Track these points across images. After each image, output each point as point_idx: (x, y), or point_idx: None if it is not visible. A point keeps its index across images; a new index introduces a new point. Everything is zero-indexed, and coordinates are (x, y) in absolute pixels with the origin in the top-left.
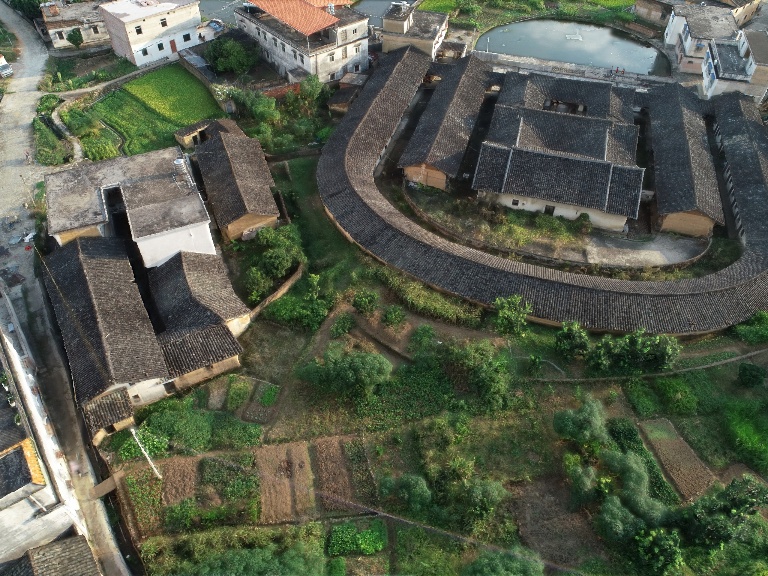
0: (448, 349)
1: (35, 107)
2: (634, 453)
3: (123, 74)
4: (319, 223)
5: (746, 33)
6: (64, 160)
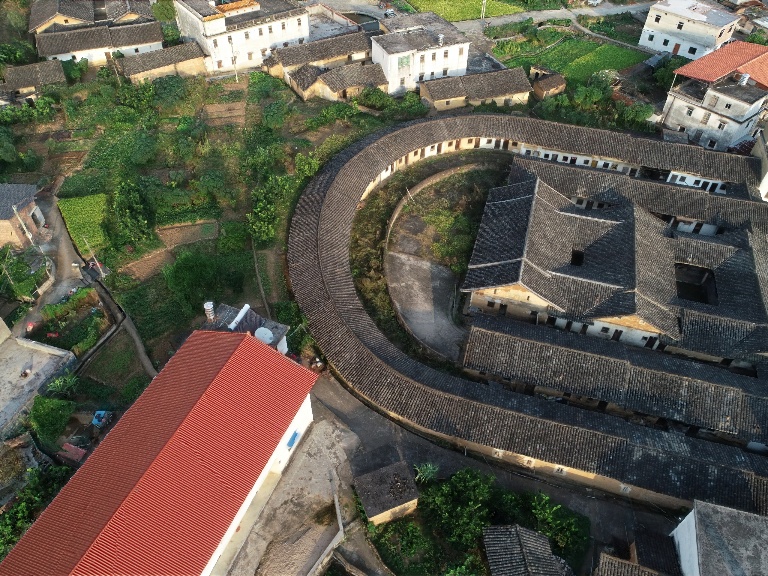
0: None
1: (553, 19)
2: (195, 212)
3: (623, 41)
4: None
5: None
6: (494, 37)
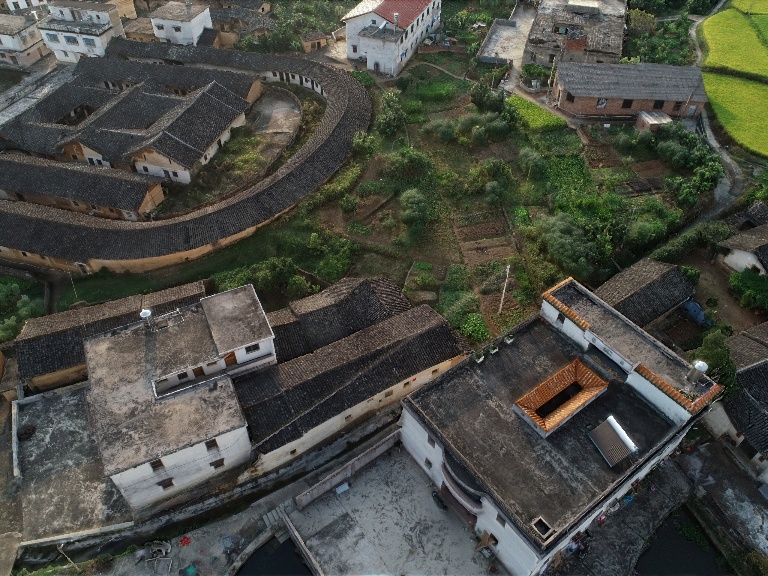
0: (393, 171)
1: None
2: None
3: None
4: (209, 263)
5: (54, 5)
6: None
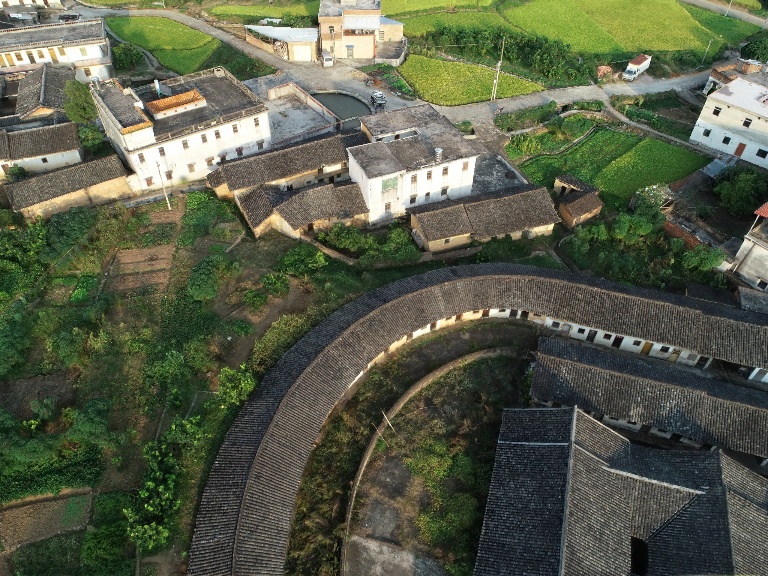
0: None
1: (580, 101)
2: (60, 474)
3: (670, 134)
4: None
5: None
6: (508, 129)
